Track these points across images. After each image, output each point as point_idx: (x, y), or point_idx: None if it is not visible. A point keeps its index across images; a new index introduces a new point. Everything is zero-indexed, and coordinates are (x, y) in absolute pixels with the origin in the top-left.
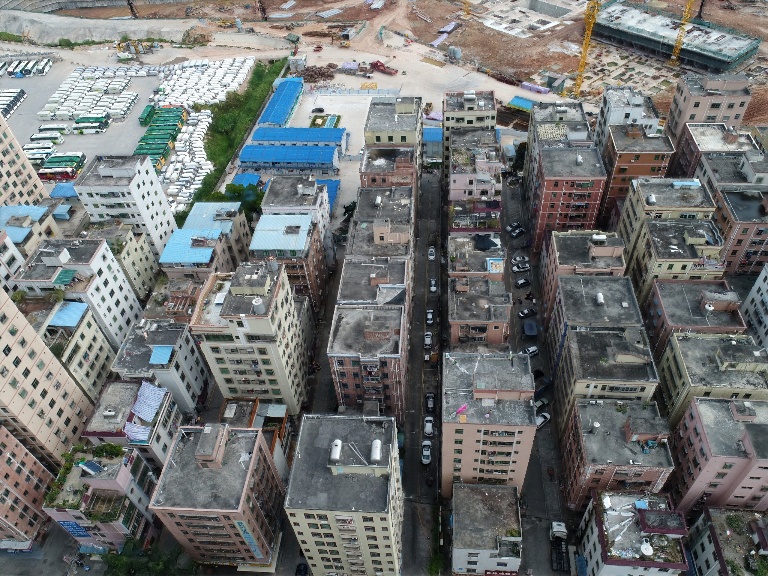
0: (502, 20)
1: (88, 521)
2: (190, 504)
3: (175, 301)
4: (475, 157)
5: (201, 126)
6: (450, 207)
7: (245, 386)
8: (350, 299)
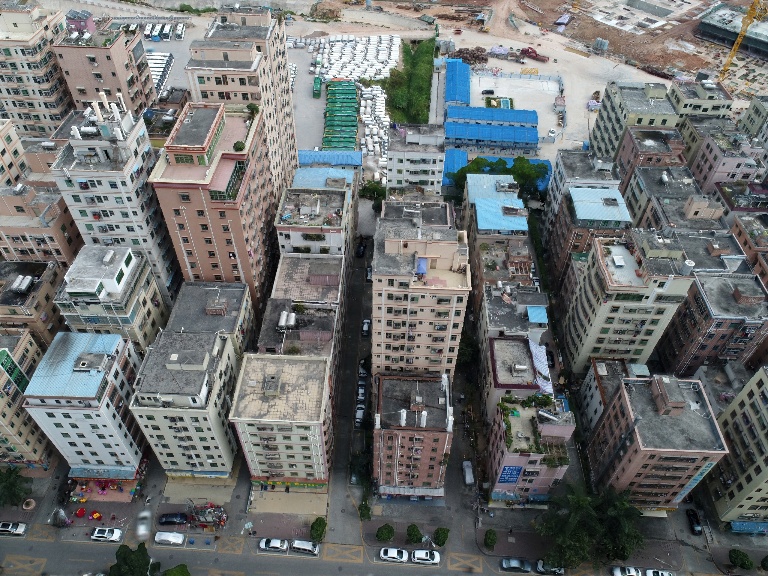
0: (611, 16)
1: (537, 466)
2: (671, 446)
3: (515, 265)
4: (739, 142)
5: (380, 101)
6: (723, 188)
7: (611, 346)
8: (699, 267)
